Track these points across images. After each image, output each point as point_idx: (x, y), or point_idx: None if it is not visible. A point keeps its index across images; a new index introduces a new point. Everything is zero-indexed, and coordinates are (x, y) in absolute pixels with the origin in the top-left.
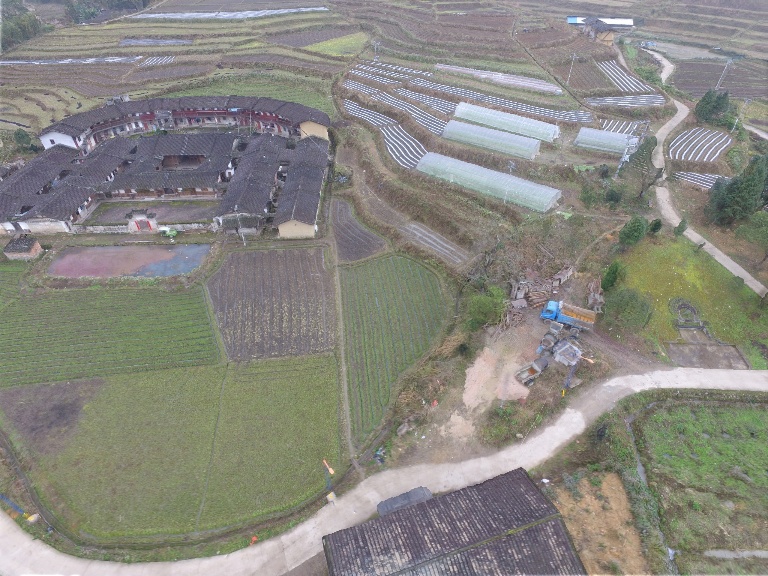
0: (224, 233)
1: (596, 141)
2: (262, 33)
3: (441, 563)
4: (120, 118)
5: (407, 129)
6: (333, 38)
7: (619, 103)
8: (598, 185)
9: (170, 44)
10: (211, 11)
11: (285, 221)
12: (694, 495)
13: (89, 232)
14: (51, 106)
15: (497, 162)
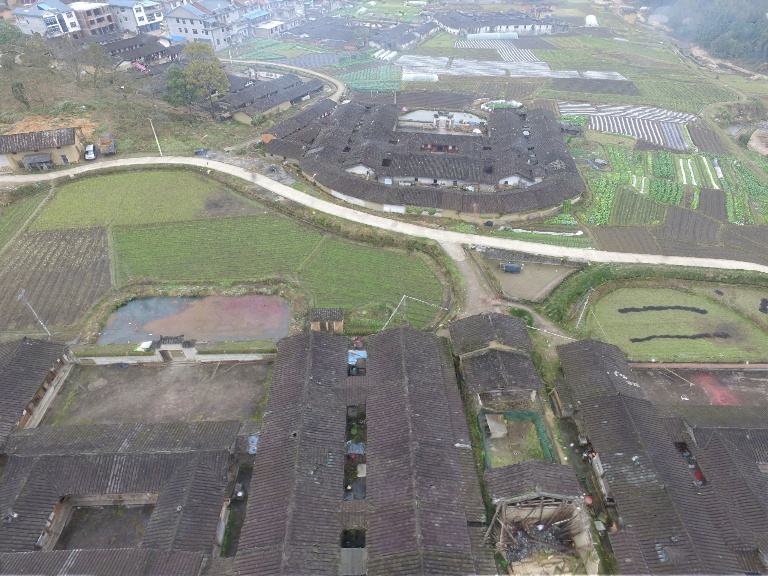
0: None
1: None
2: None
3: None
4: None
5: None
6: None
7: None
8: None
9: None
10: None
11: None
12: None
13: None
14: None
15: None
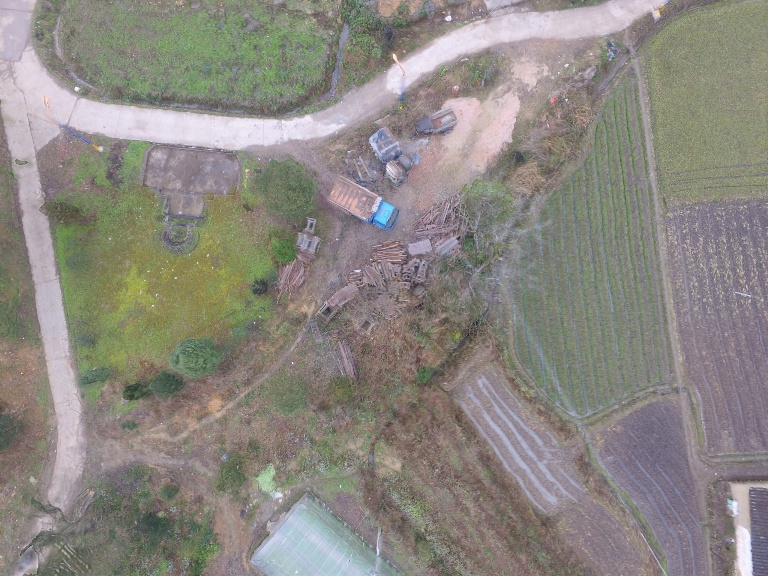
0: None
1: None
2: None
3: None
4: None
5: None
6: None
7: None
8: None
9: None
10: None
11: None
12: (307, 8)
13: None
14: None
15: None
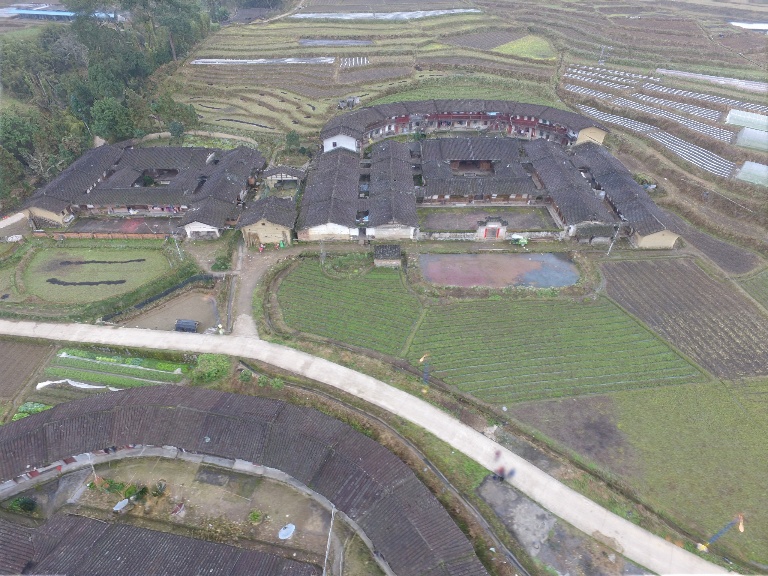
0: (573, 242)
1: None
2: (436, 35)
3: None
4: (379, 121)
5: (680, 136)
6: (512, 41)
7: None
8: None
9: (354, 45)
10: (365, 11)
11: (658, 231)
12: None
13: (432, 239)
14: (280, 107)
15: None
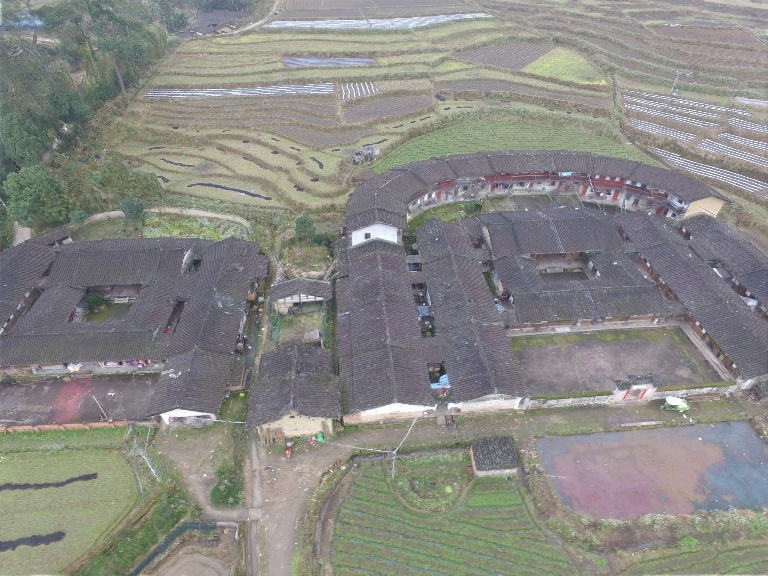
0: (749, 399)
1: None
2: (450, 49)
3: None
4: None
5: None
6: (541, 56)
7: None
8: None
9: (354, 65)
10: (357, 18)
11: None
12: None
13: (546, 406)
14: (274, 163)
15: None
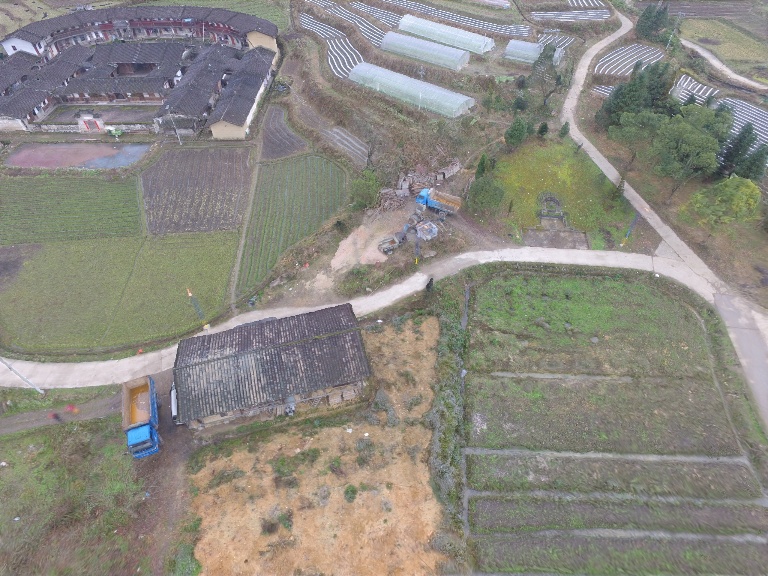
0: (164, 134)
1: (522, 53)
2: None
3: (258, 354)
4: (80, 27)
5: (352, 42)
6: None
7: (562, 18)
8: (512, 95)
9: None
10: None
11: (215, 122)
12: (498, 335)
13: (44, 131)
14: (19, 16)
15: (426, 73)
